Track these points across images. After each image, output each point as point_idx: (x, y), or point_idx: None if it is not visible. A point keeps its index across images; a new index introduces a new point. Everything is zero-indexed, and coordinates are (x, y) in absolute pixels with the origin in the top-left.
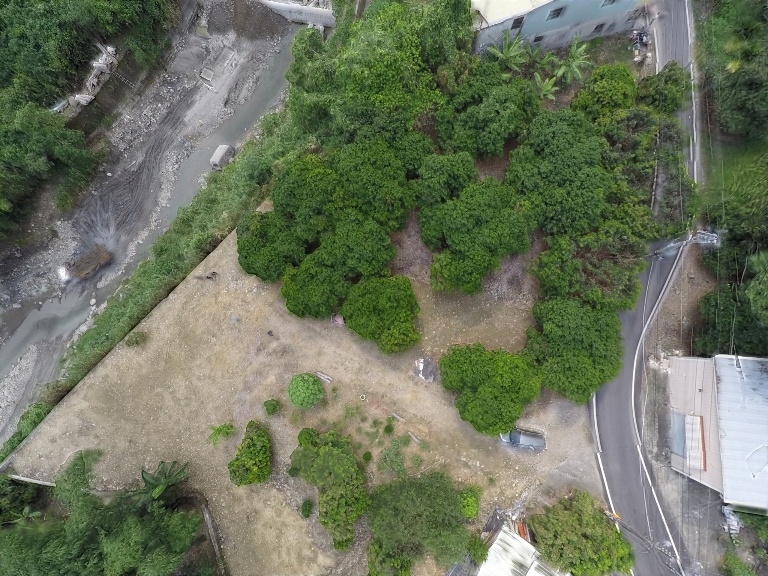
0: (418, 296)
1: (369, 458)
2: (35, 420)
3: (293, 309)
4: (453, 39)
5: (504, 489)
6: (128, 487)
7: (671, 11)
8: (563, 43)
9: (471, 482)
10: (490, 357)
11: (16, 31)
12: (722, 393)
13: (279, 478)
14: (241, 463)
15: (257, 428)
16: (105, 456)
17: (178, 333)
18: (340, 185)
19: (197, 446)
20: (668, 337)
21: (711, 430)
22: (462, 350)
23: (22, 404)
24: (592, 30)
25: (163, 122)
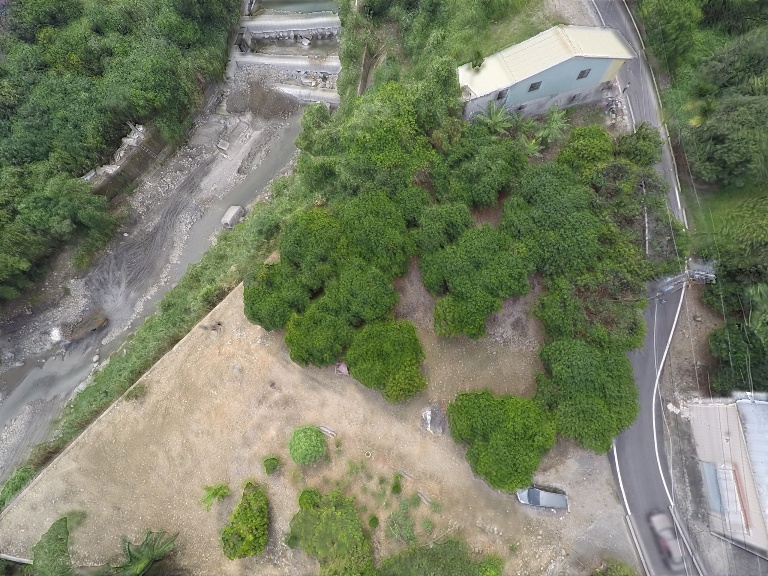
0: (423, 345)
1: (376, 525)
2: (21, 486)
3: (297, 359)
4: (445, 108)
5: (527, 561)
6: (111, 564)
7: (640, 81)
8: (546, 110)
9: (489, 553)
10: (500, 407)
11: (57, 113)
12: (751, 442)
13: (277, 551)
14: (236, 532)
15: (255, 491)
16: (90, 527)
17: (179, 387)
18: (344, 237)
19: (190, 513)
20: (684, 383)
21: (747, 485)
22: (470, 400)
23: (9, 470)
24: (571, 98)
25: (180, 187)
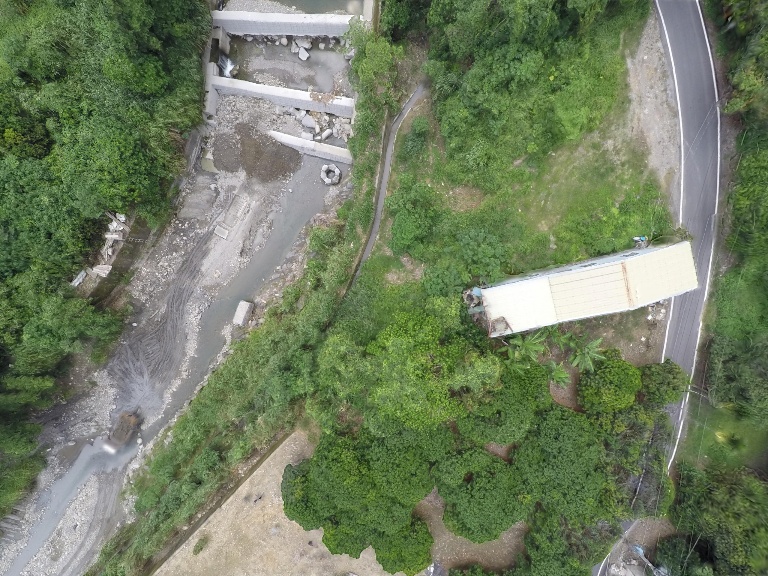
0: (432, 516)
1: None
2: None
3: None
4: (479, 383)
5: None
6: None
7: None
8: None
9: None
10: None
11: (24, 224)
12: None
13: None
14: None
15: None
16: None
17: (234, 538)
18: (373, 486)
19: None
20: (629, 551)
21: None
22: None
23: (95, 523)
24: None
25: (180, 270)
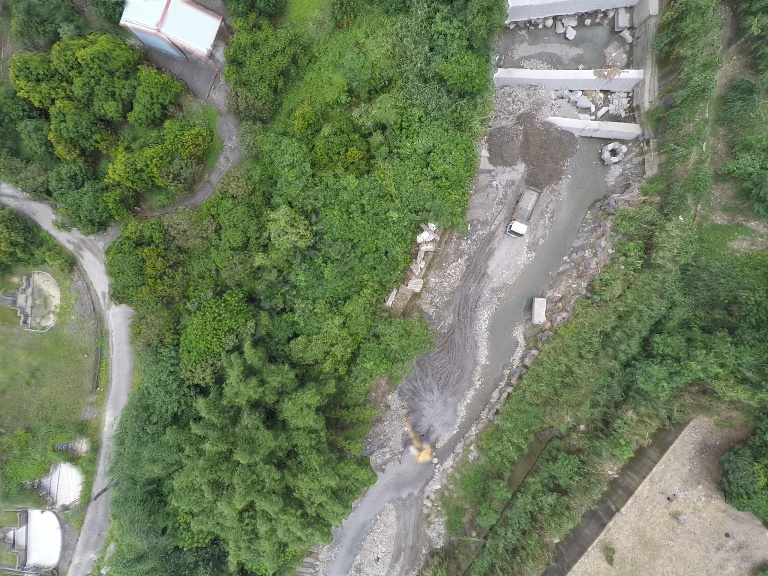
0: None
1: None
2: None
3: None
4: None
5: None
6: None
7: None
8: None
9: None
10: None
11: (370, 245)
12: None
13: None
14: None
15: None
16: None
17: (639, 542)
18: None
19: None
20: None
21: None
22: None
23: (397, 553)
24: None
25: (464, 276)
